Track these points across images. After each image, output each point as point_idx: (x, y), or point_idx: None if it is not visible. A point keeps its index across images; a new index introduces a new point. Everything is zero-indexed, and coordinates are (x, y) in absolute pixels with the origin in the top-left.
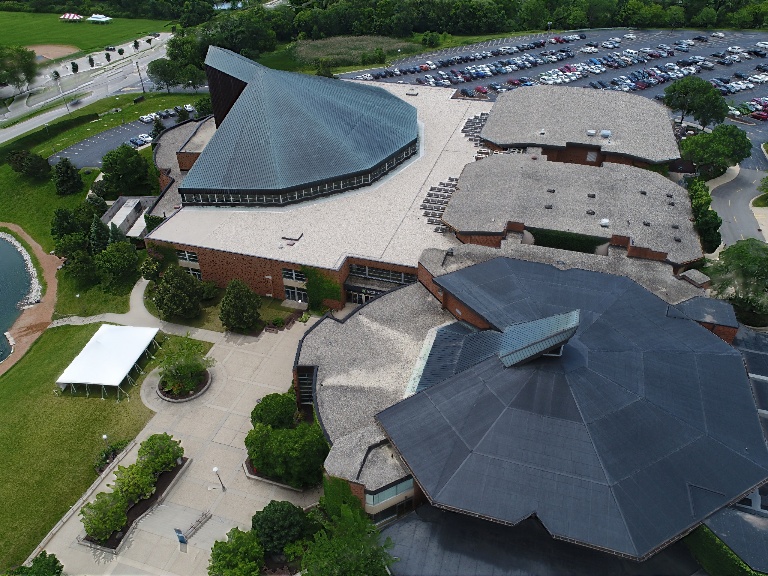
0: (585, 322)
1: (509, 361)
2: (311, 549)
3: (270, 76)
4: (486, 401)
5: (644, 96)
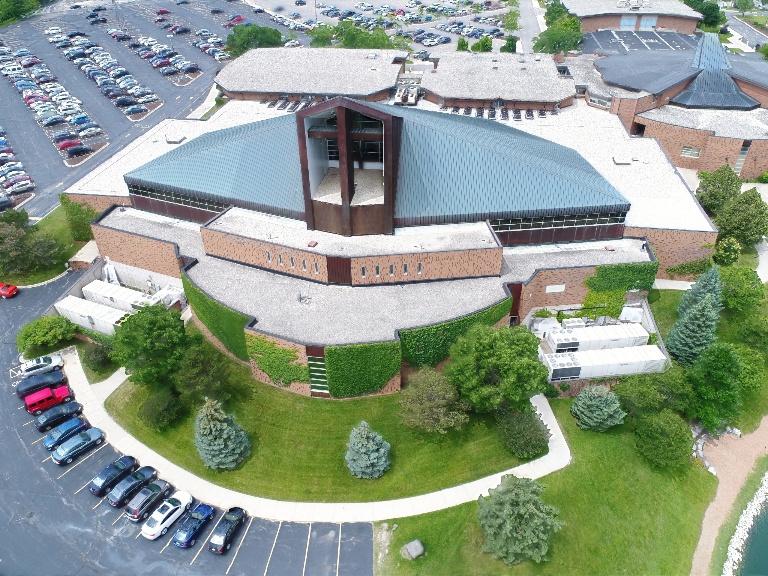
0: (668, 58)
1: (730, 66)
2: None
3: None
4: None
5: (157, 79)
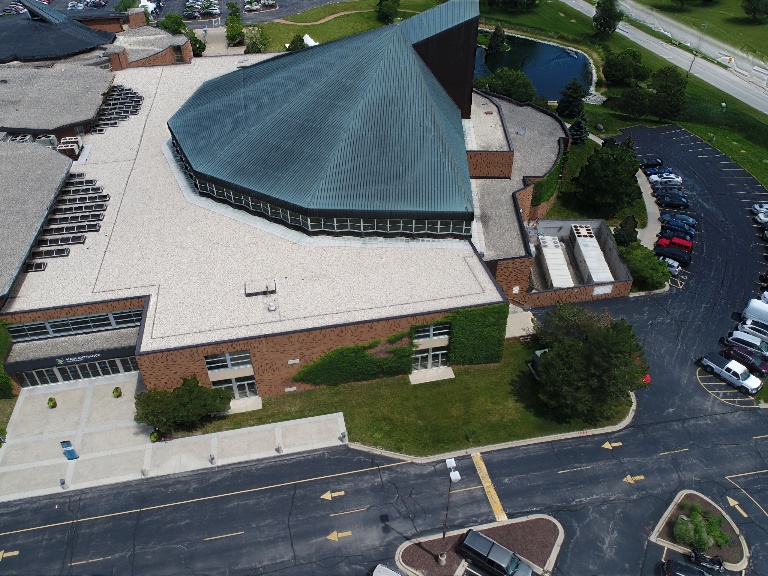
0: None
1: None
2: (139, 1)
3: (377, 29)
4: (75, 13)
5: None
